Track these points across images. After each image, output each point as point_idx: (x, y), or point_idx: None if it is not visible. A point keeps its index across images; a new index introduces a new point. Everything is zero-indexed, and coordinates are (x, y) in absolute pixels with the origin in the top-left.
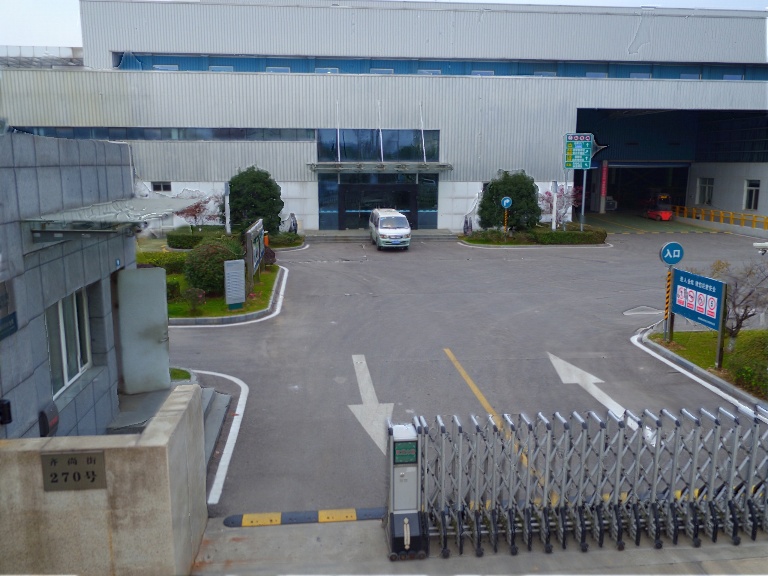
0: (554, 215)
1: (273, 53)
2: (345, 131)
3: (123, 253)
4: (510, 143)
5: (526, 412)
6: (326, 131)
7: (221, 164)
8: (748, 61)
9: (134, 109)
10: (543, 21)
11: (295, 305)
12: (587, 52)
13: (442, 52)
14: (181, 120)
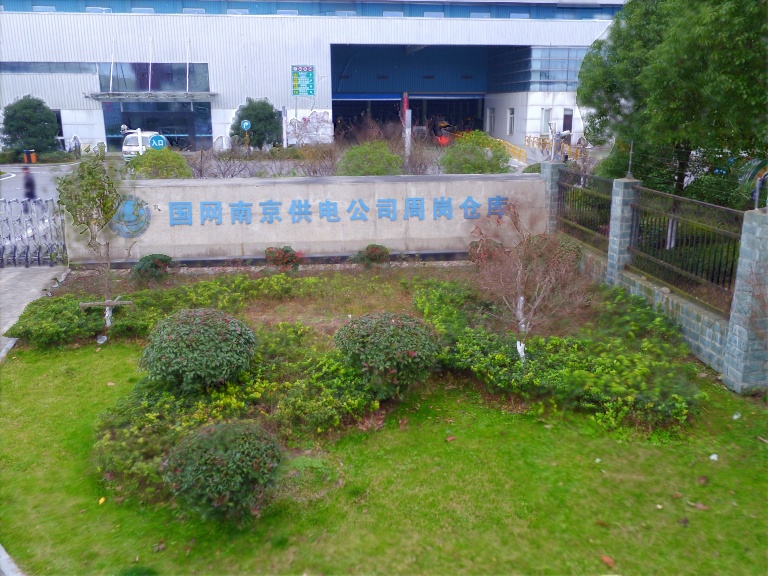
0: (284, 135)
1: None
2: (123, 64)
3: None
4: (272, 75)
5: None
6: (106, 64)
7: (14, 94)
8: (527, 1)
9: None
10: None
11: None
12: None
13: None
14: None
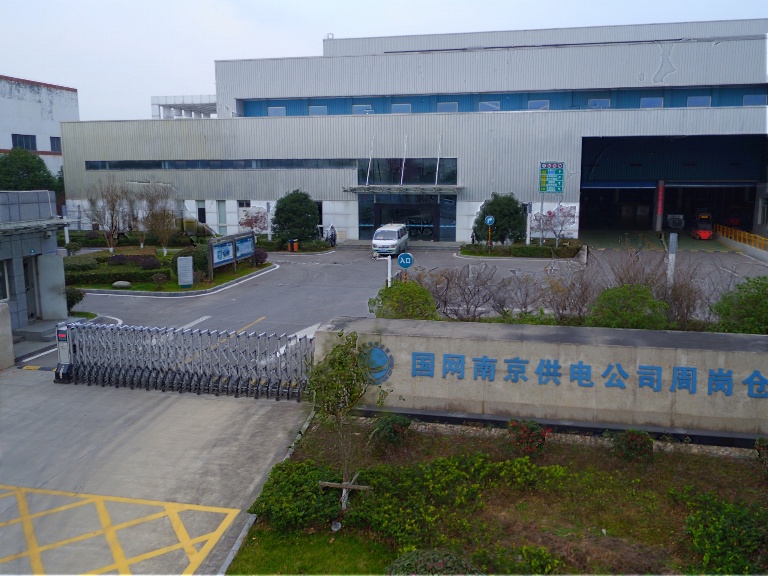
0: (528, 232)
1: (355, 94)
2: (379, 160)
3: (41, 247)
4: (519, 168)
5: (232, 346)
6: (365, 160)
7: (286, 187)
8: None
9: (226, 146)
10: (592, 53)
11: (234, 289)
12: (637, 79)
13: (497, 86)
14: (258, 154)
